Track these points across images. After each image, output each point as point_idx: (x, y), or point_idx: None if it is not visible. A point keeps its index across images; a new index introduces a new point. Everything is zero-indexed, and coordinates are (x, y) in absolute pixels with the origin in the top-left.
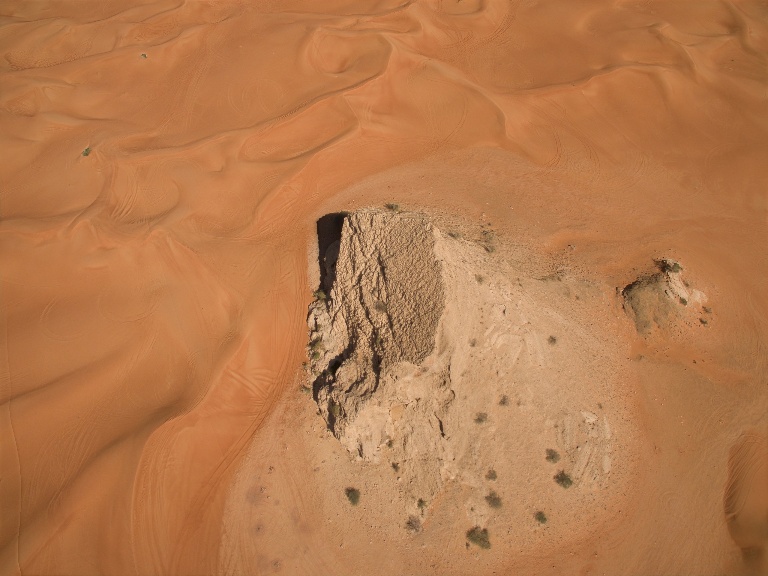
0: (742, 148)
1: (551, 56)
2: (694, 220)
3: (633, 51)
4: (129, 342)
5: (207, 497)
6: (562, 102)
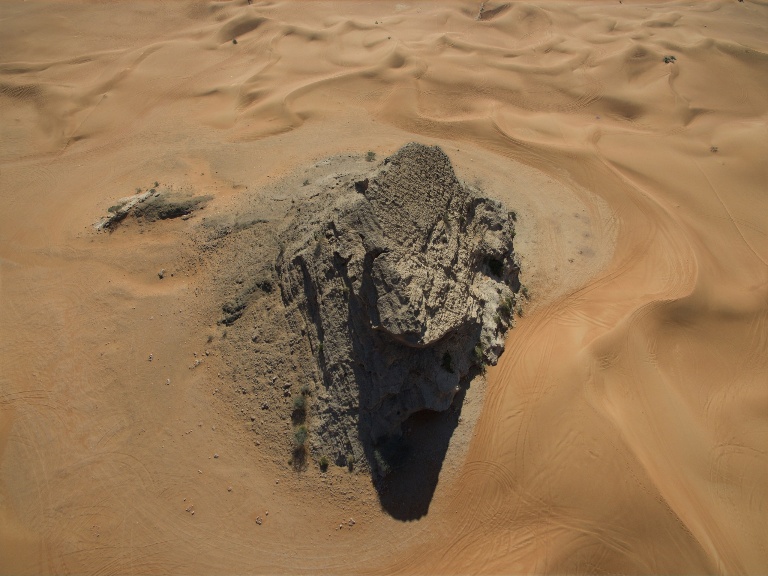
0: None
1: None
2: (0, 255)
3: None
4: (745, 419)
5: (630, 261)
6: None
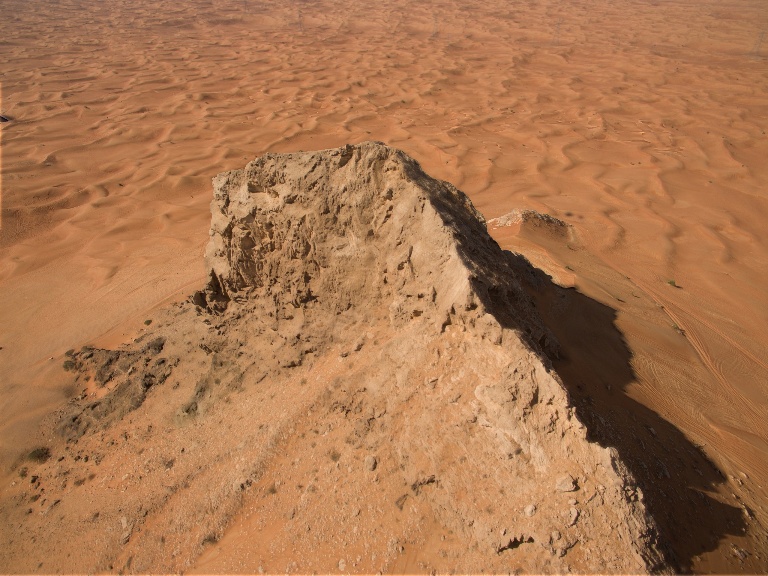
0: None
1: None
2: None
3: None
4: None
5: None
6: None
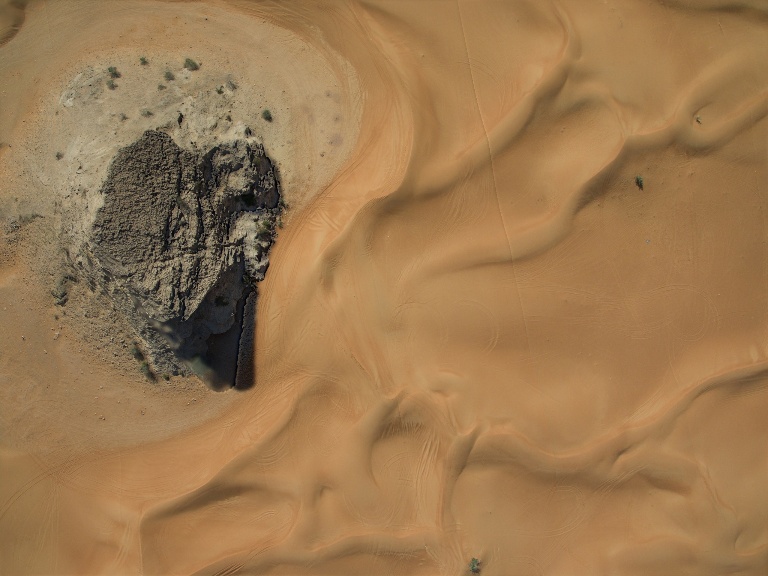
0: None
1: None
2: None
3: None
4: (420, 283)
5: (368, 146)
6: None
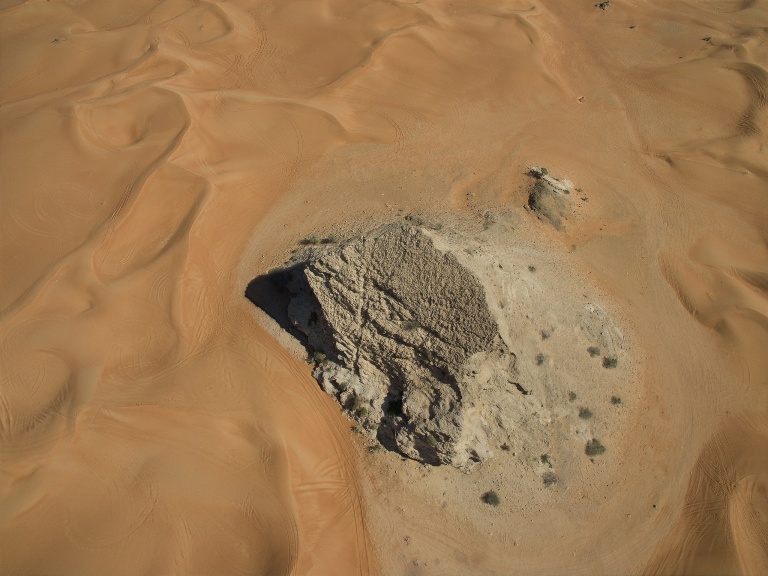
0: (506, 67)
1: (323, 49)
2: (520, 132)
3: (383, 22)
4: (157, 550)
5: None
6: (364, 84)
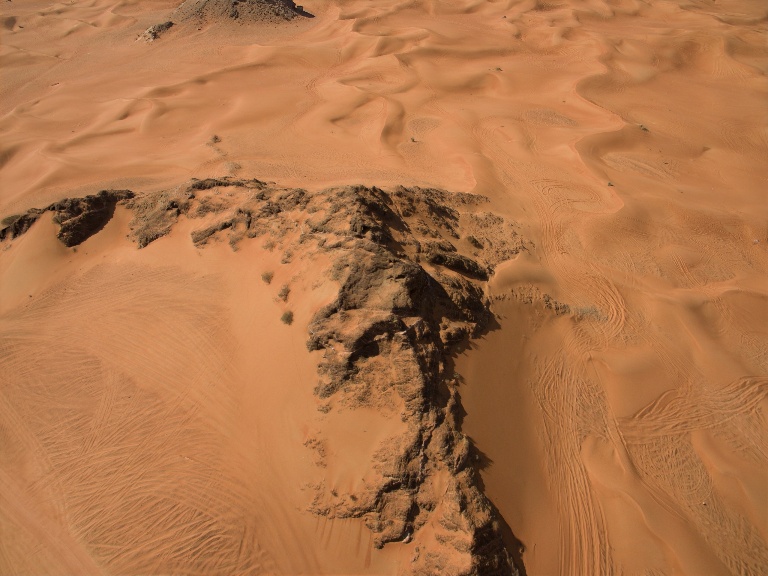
0: (94, 86)
1: (254, 83)
2: (137, 58)
3: (181, 96)
4: None
5: None
6: None
